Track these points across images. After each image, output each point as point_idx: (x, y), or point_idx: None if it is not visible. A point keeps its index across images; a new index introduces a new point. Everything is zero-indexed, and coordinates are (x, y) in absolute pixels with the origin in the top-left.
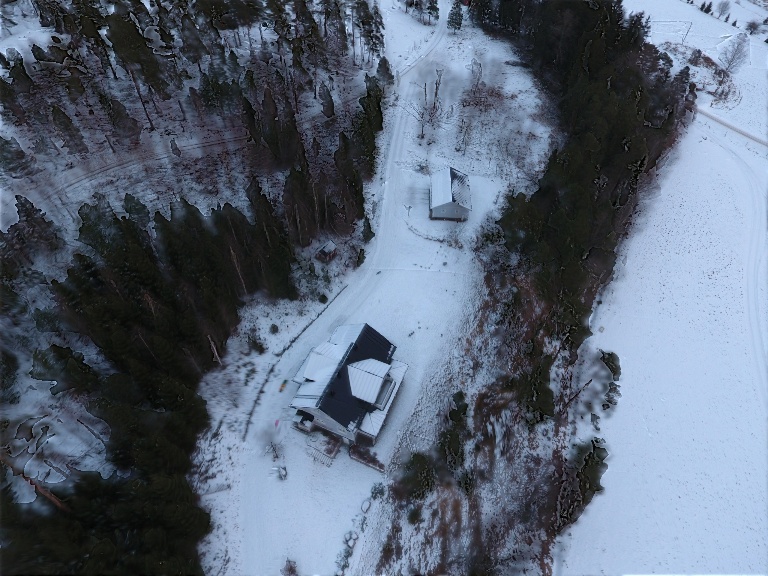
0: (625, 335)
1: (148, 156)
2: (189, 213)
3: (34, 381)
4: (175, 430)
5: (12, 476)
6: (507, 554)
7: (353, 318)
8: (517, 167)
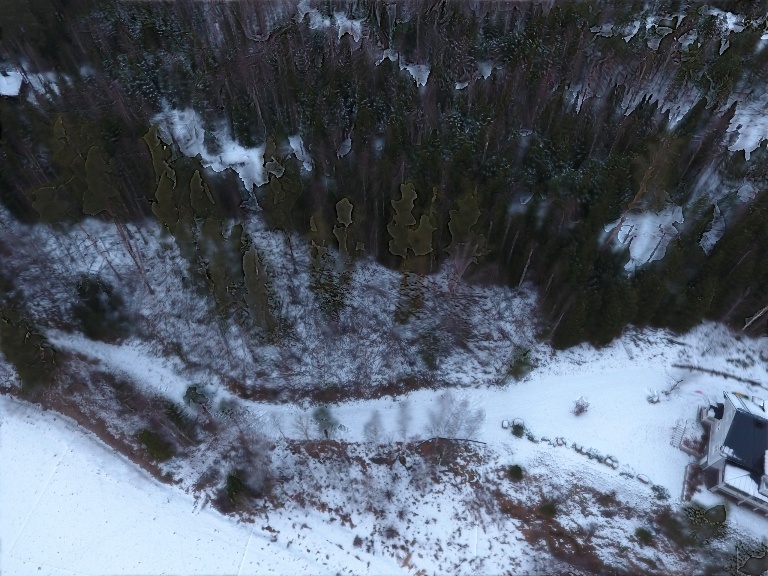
0: None
1: None
2: None
3: (675, 217)
4: (671, 303)
5: (610, 227)
6: None
7: None
8: None
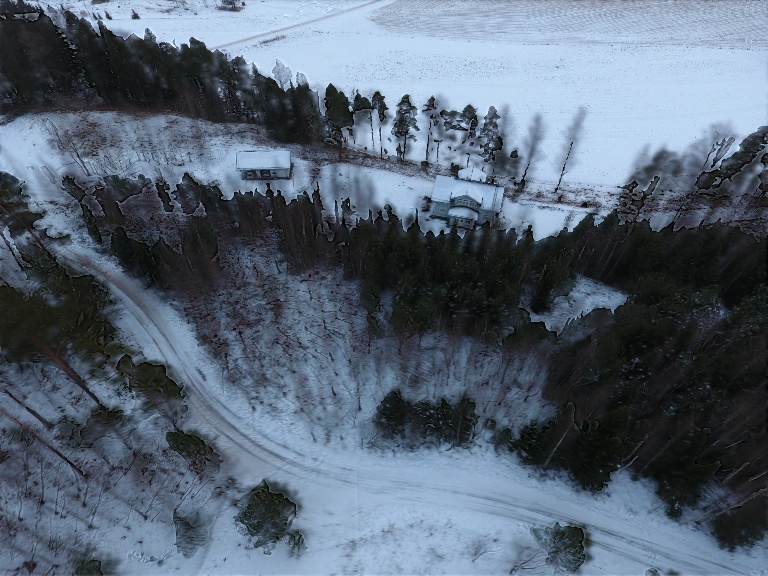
0: (362, 139)
1: (195, 393)
2: (376, 247)
3: None
4: None
5: None
6: None
7: (404, 215)
8: (217, 136)
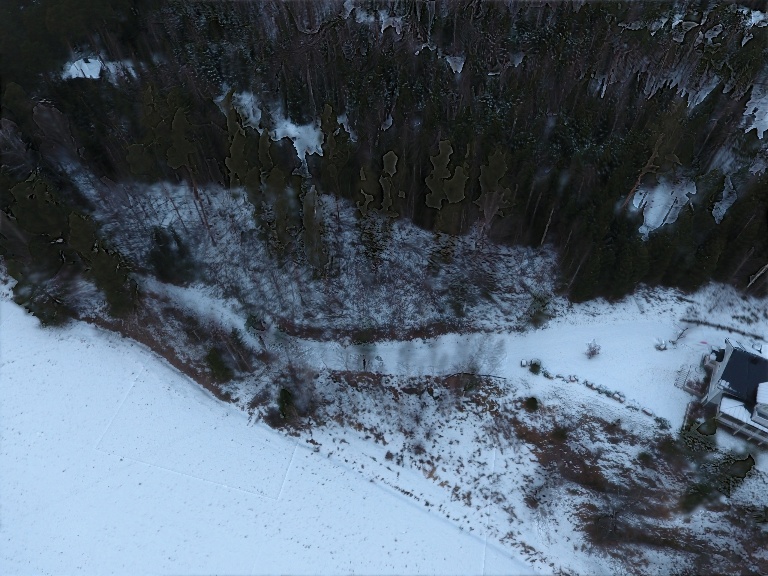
0: None
1: None
2: None
3: (690, 191)
4: (680, 262)
5: None
6: (621, 571)
7: None
8: None
